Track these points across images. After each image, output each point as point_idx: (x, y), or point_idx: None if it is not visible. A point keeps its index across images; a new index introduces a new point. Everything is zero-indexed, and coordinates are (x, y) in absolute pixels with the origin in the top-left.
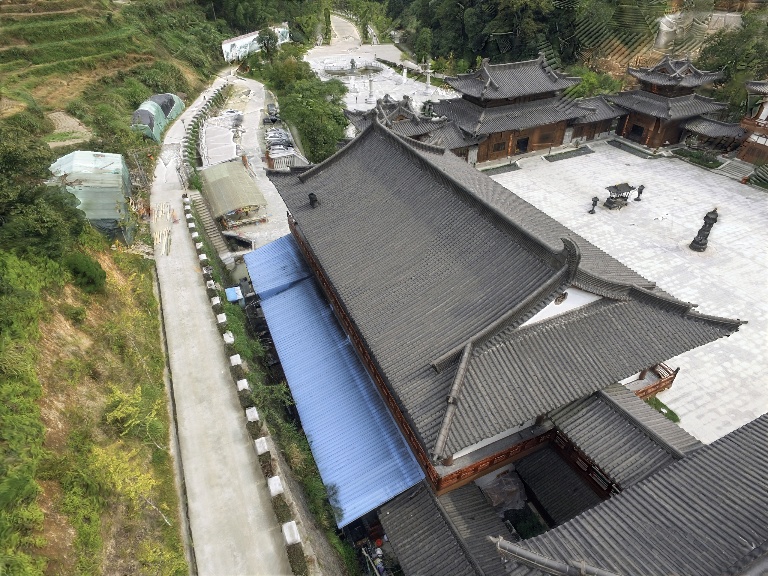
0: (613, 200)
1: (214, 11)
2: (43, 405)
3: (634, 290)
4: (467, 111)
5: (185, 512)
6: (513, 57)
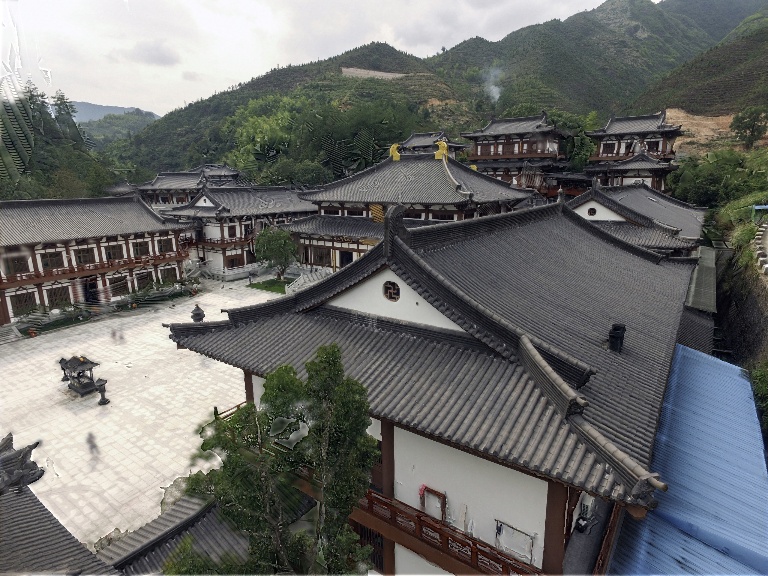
0: None
1: None
2: None
3: None
4: None
5: None
6: None
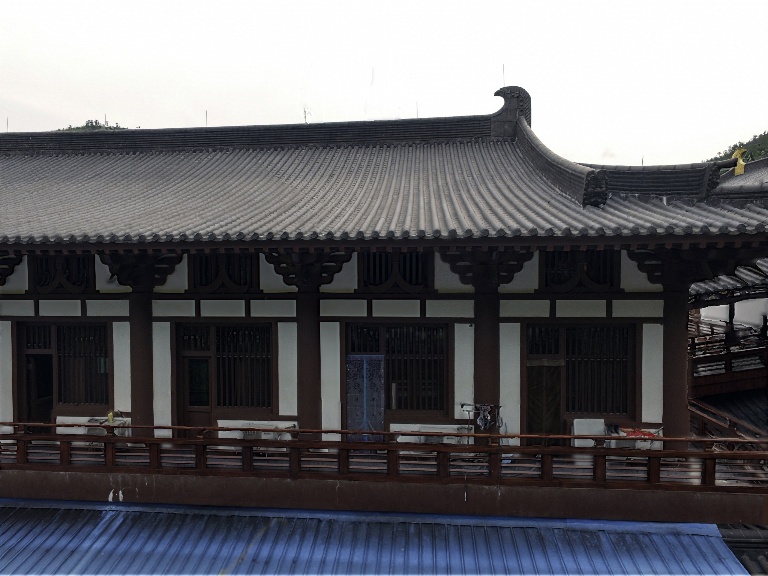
0: None
1: None
2: None
3: None
4: None
5: None
6: None
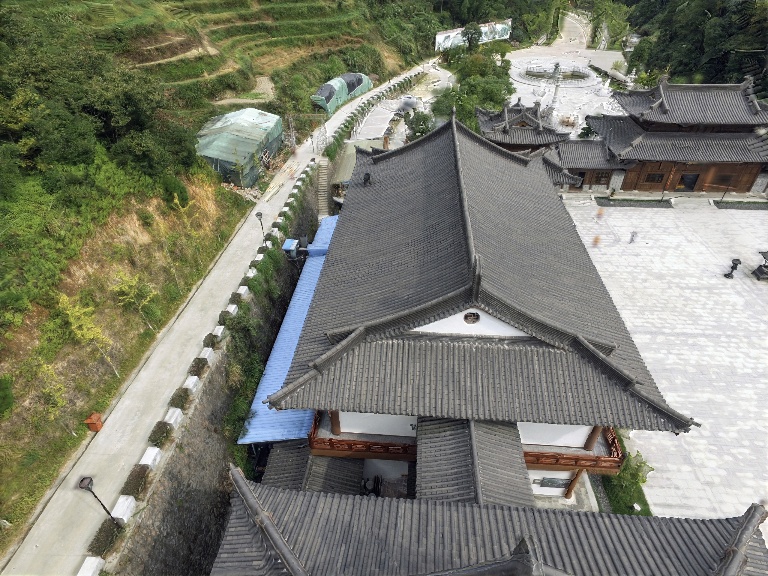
0: (766, 269)
1: (442, 3)
2: (76, 264)
3: (578, 342)
4: (627, 131)
5: (136, 375)
6: (704, 77)
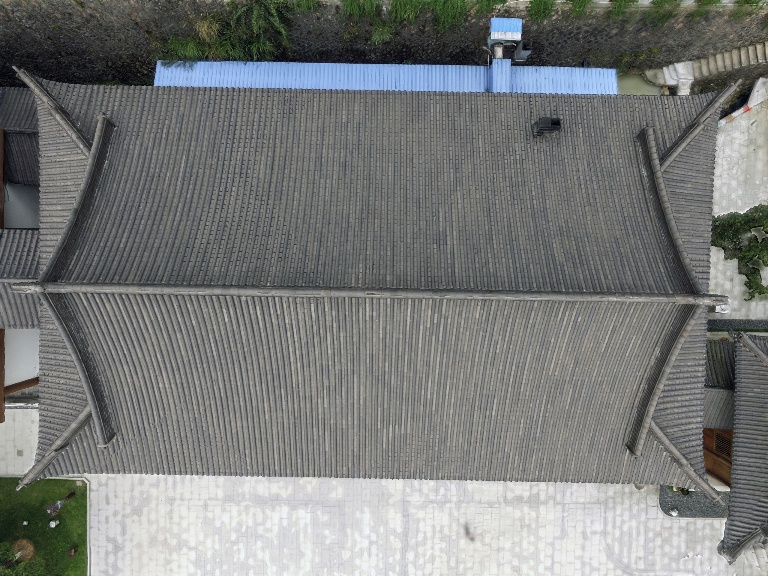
0: None
1: None
2: None
3: None
4: None
5: None
6: None
